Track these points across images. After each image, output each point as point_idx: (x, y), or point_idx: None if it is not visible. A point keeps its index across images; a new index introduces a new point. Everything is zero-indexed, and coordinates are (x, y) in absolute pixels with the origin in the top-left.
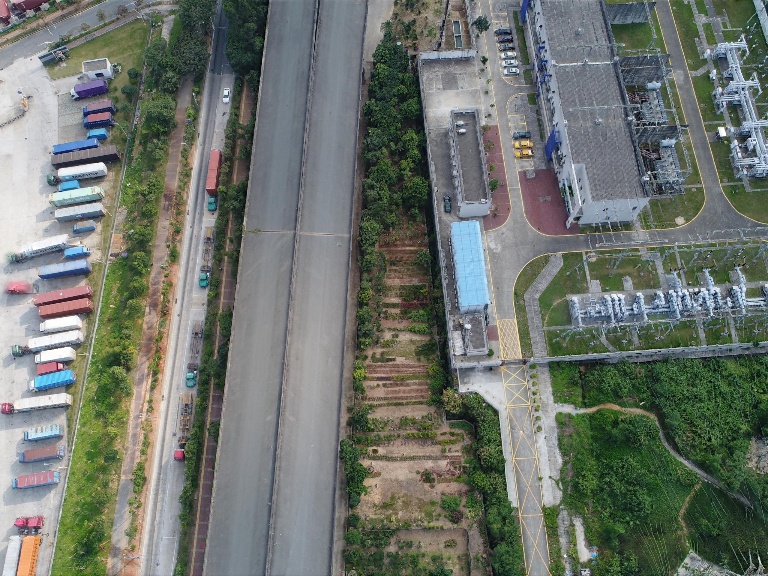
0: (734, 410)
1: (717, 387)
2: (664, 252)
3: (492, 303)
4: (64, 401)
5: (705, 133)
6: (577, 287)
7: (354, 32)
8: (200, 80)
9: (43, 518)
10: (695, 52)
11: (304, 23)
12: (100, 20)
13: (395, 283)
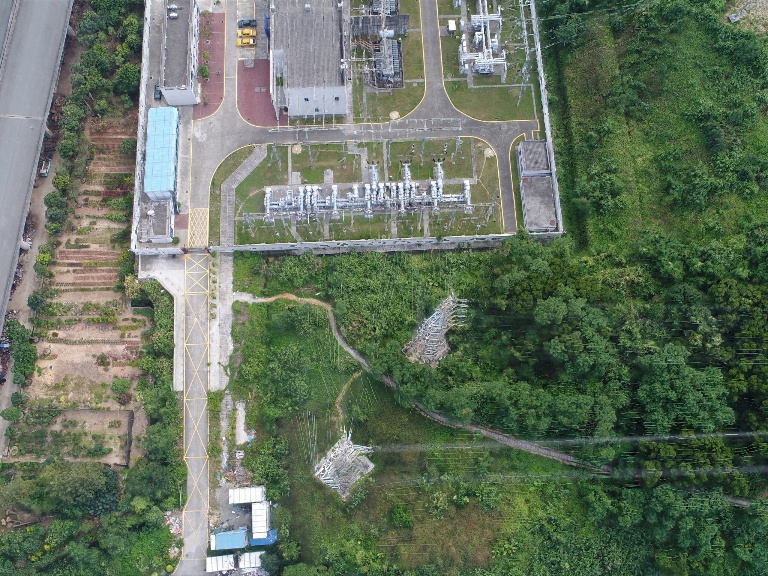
0: (403, 302)
1: (392, 279)
2: (372, 146)
3: (187, 192)
4: None
5: (438, 27)
6: (277, 178)
7: None
8: None
9: None
10: None
11: None
12: None
13: (101, 171)
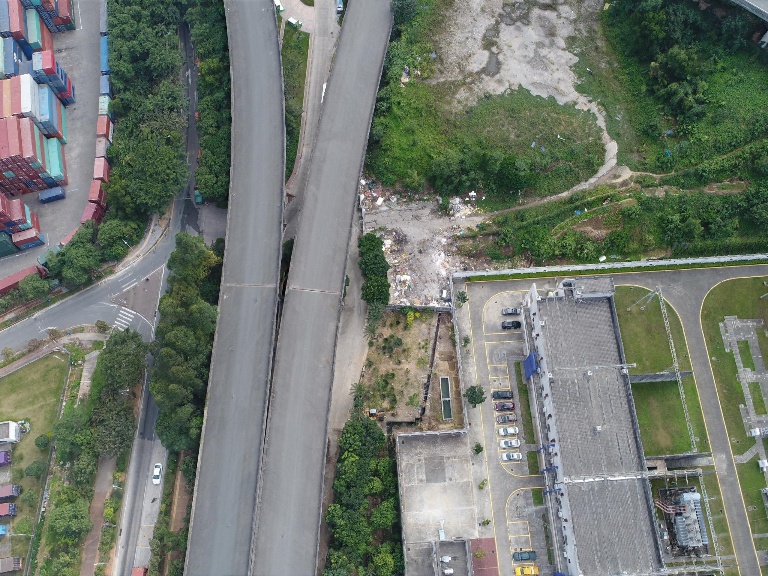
0: None
1: None
2: None
3: None
4: None
5: (755, 552)
6: None
7: (316, 409)
8: None
9: None
10: (740, 426)
11: (253, 399)
12: (6, 359)
13: None
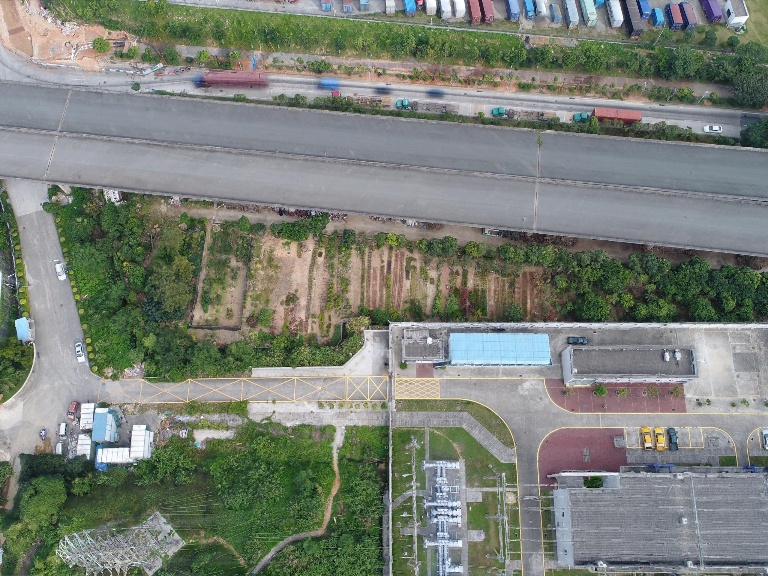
0: None
1: None
2: None
3: (459, 375)
4: (388, 5)
5: None
6: (474, 473)
7: None
8: (731, 103)
9: (297, 2)
10: None
11: None
12: None
13: (490, 285)
